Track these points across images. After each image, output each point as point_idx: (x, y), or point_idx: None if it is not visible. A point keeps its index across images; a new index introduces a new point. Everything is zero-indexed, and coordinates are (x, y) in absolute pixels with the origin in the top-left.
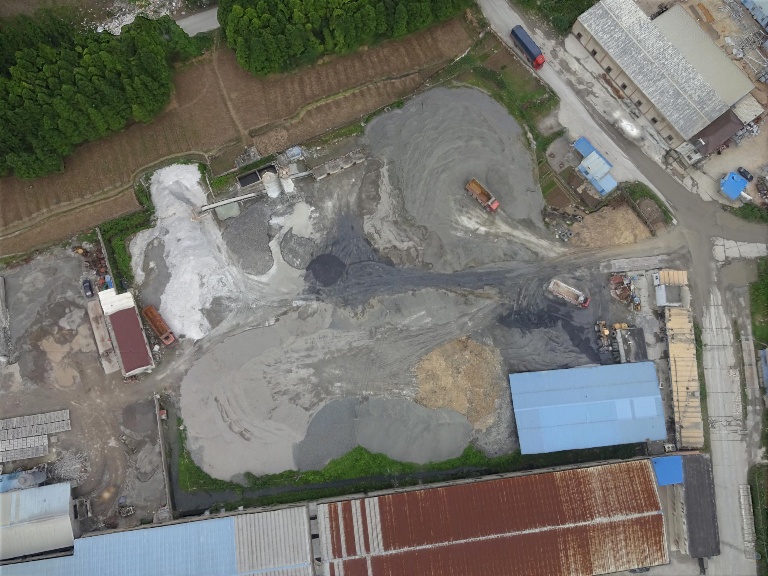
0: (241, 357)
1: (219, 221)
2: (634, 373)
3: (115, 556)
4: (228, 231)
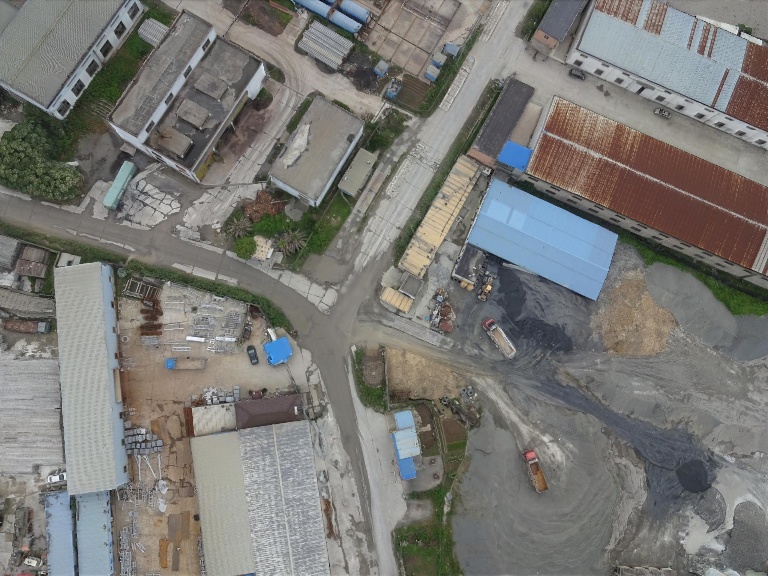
0: None
1: (767, 573)
2: (491, 242)
3: None
4: None
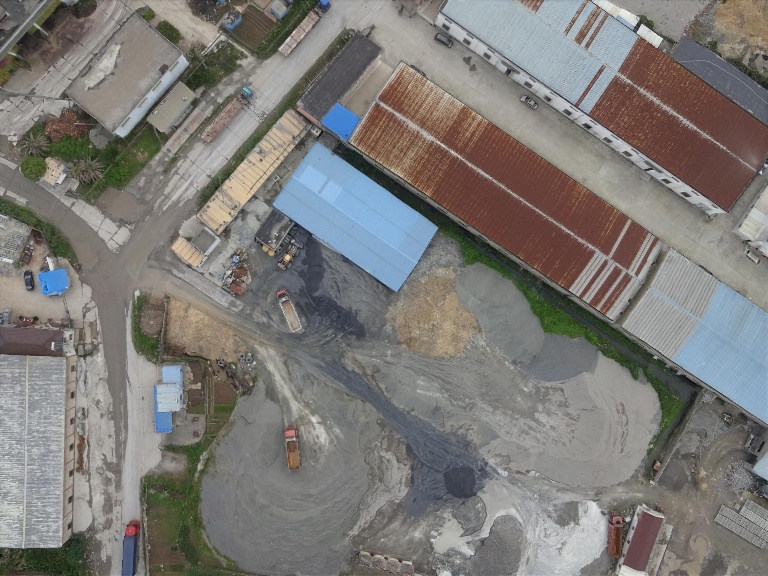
0: (580, 467)
1: None
2: (297, 210)
3: (764, 400)
4: (511, 571)
